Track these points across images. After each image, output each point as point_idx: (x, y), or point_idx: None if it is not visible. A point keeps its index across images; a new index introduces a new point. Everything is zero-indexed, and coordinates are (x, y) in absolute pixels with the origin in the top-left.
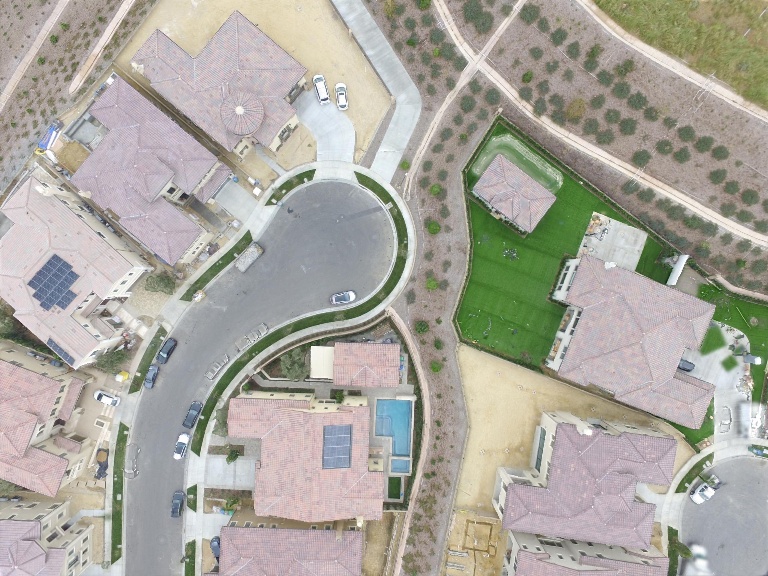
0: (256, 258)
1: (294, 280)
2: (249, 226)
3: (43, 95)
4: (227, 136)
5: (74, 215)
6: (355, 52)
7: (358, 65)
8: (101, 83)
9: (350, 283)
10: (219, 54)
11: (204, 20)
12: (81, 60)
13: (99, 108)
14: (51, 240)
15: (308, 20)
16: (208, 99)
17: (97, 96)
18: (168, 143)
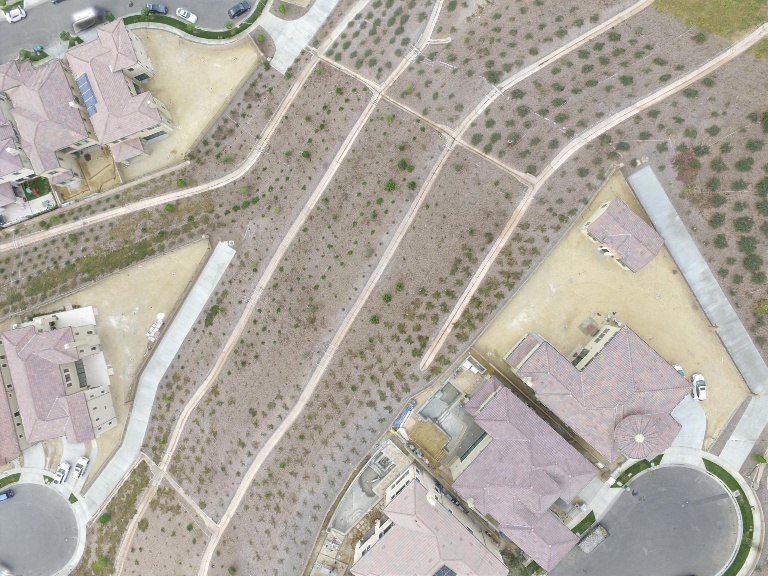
0: (601, 541)
1: (635, 561)
2: (593, 507)
3: (386, 363)
4: (612, 451)
5: (454, 519)
6: (713, 342)
7: (715, 355)
8: (456, 365)
9: (691, 567)
10: (610, 371)
11: (562, 306)
12: (431, 335)
13: (487, 419)
14: (440, 551)
15: (666, 309)
16: (598, 417)
17: (452, 378)
18: (556, 458)
